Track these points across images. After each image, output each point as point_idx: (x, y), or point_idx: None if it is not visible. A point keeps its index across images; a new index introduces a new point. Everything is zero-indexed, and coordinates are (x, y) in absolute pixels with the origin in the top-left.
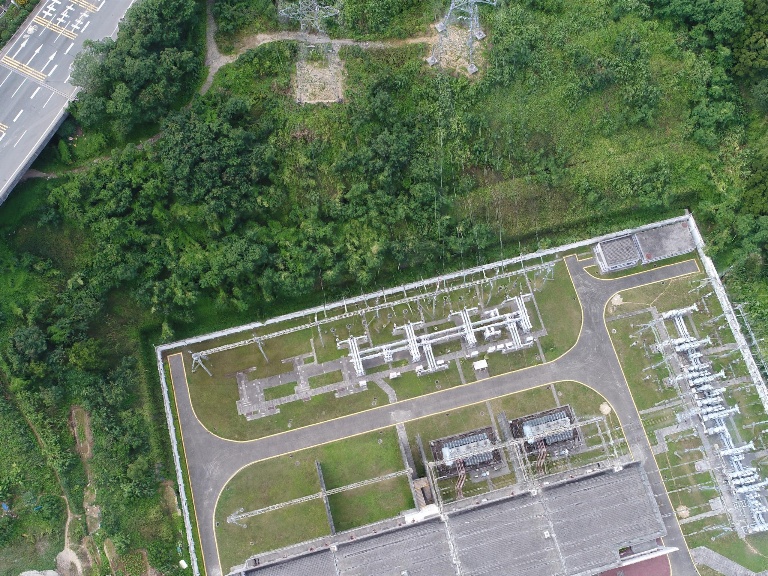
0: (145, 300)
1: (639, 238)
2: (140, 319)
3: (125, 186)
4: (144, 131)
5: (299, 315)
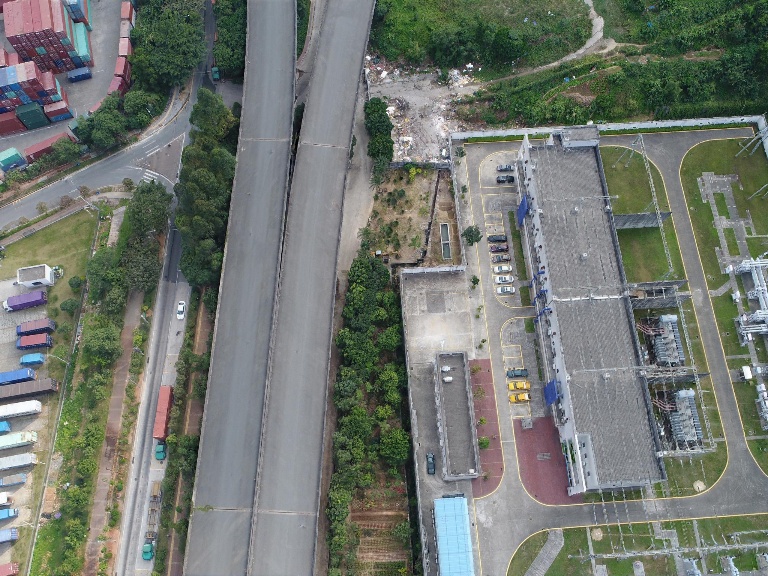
0: None
1: None
2: None
3: None
4: None
5: None
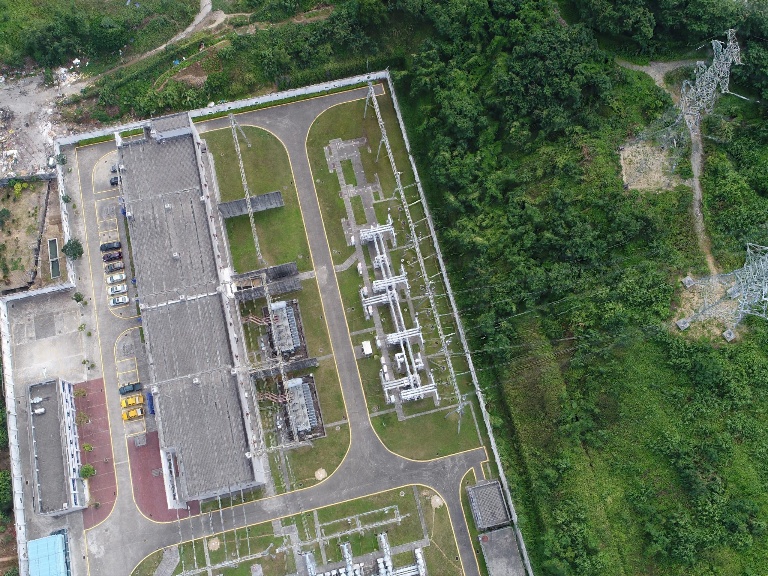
0: None
1: (507, 530)
2: None
3: (517, 7)
4: (575, 18)
5: None
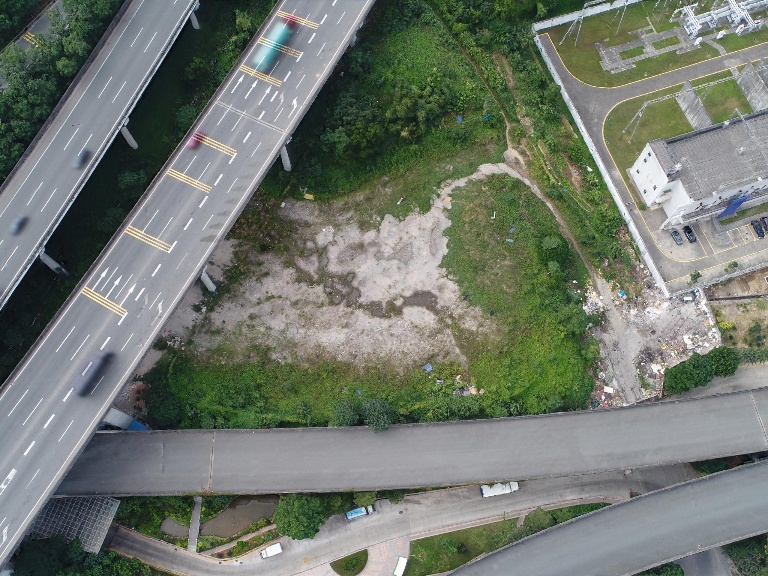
0: None
1: None
2: (518, 3)
3: None
4: None
5: (634, 1)
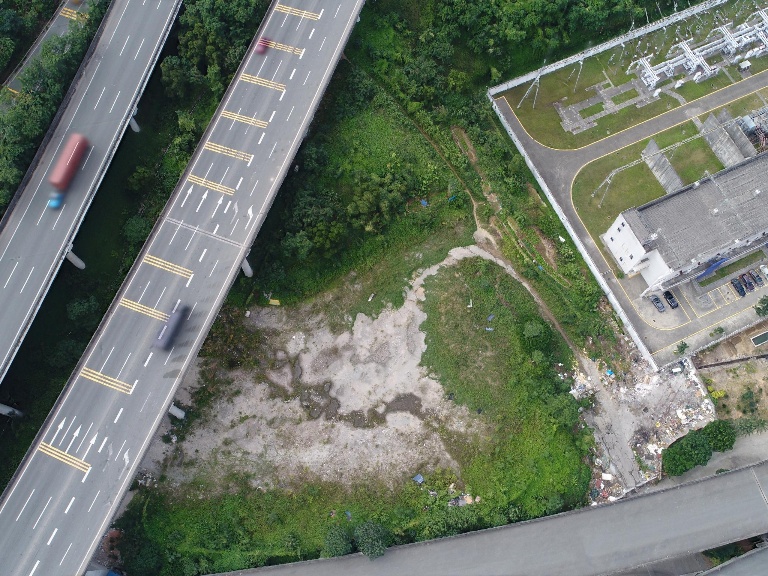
0: (483, 44)
1: None
2: (471, 69)
3: None
4: None
5: (588, 55)
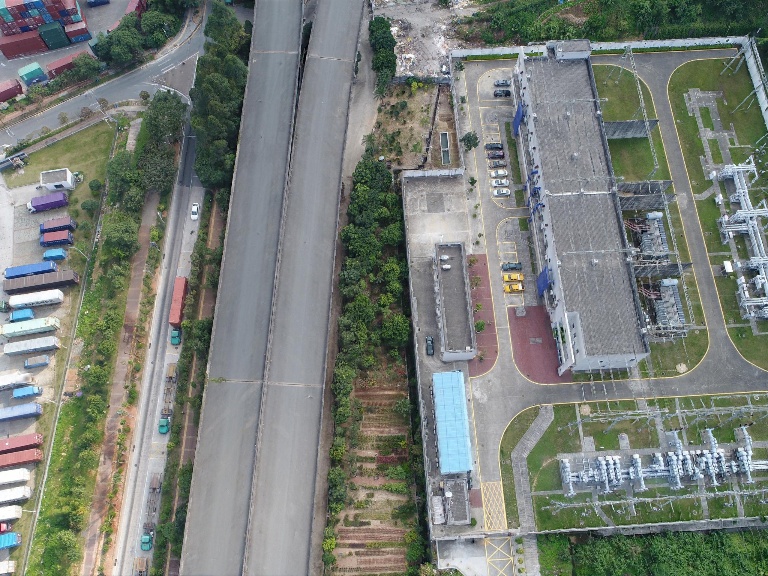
0: None
1: None
2: None
3: None
4: None
5: None
